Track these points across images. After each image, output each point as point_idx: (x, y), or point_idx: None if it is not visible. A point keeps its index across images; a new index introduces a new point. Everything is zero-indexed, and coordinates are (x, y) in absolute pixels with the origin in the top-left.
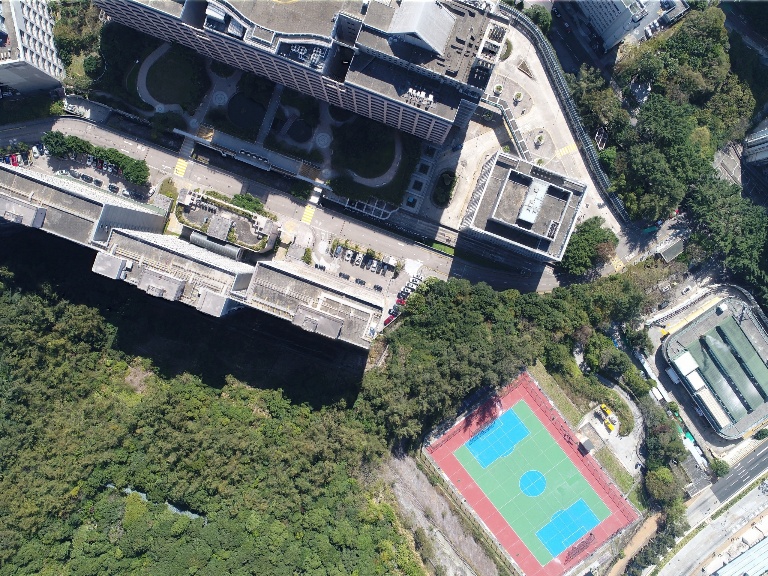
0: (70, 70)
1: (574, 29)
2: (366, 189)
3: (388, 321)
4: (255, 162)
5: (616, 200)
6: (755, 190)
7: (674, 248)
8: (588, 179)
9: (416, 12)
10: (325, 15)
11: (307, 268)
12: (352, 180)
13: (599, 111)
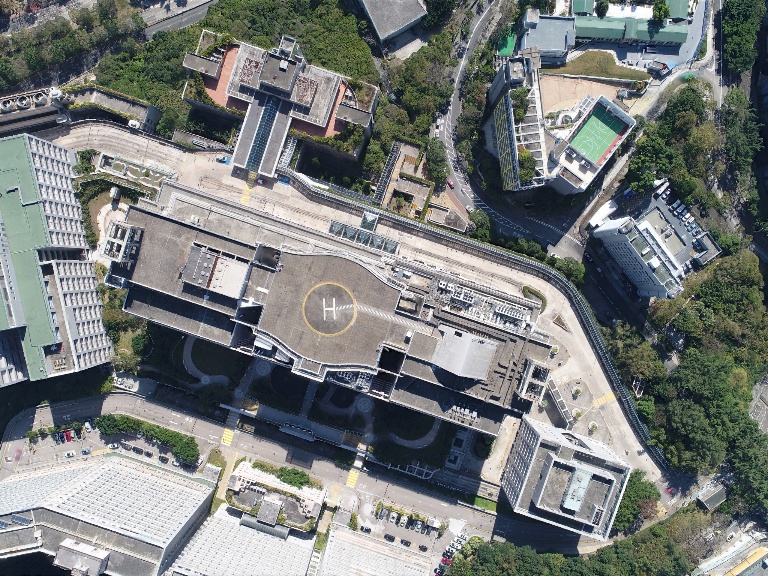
0: (118, 346)
1: (607, 273)
2: (408, 451)
3: None
4: (299, 432)
5: (656, 450)
6: None
7: (716, 496)
8: (627, 427)
9: (460, 354)
10: (370, 345)
11: (354, 535)
12: (394, 446)
13: (636, 370)
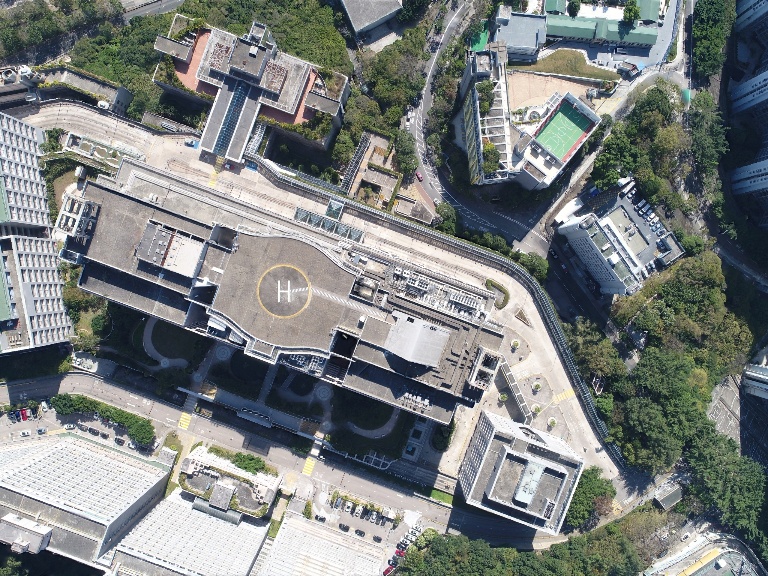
0: (79, 326)
1: (571, 270)
2: (366, 440)
3: (387, 572)
4: (257, 418)
5: (614, 448)
6: (754, 421)
7: (672, 496)
8: (586, 424)
9: (411, 340)
10: (323, 329)
11: (307, 524)
12: (352, 435)
13: (595, 366)
